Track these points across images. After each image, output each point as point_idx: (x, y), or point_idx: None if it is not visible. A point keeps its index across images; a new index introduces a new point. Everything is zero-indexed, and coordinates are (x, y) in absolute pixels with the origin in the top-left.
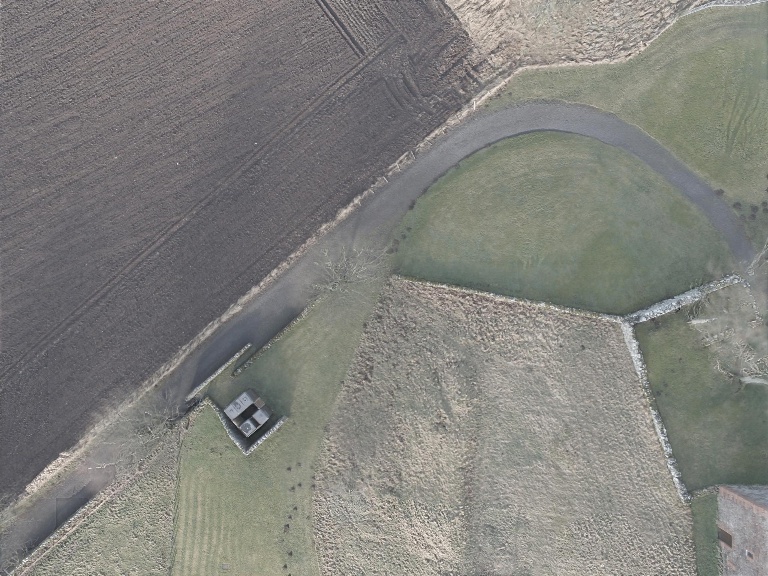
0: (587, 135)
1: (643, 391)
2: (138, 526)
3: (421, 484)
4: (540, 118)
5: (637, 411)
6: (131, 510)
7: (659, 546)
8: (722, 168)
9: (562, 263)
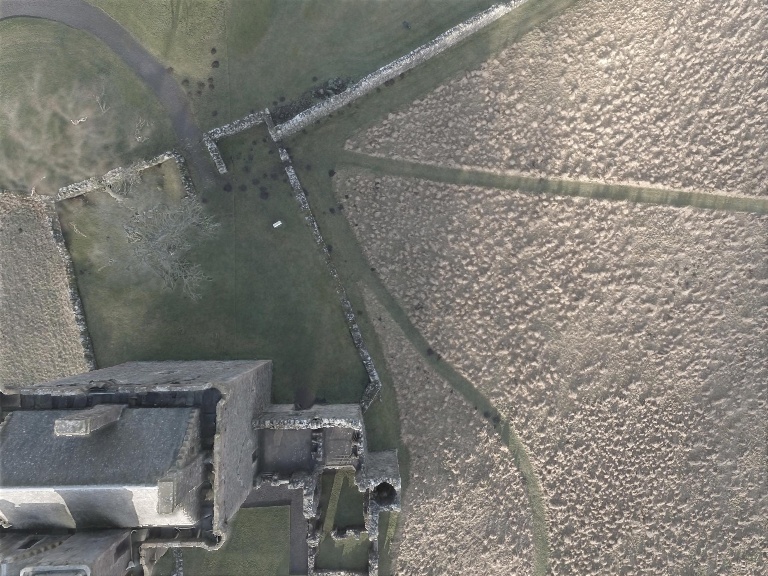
0: (54, 19)
1: (65, 270)
2: None
3: None
4: (12, 4)
5: (61, 291)
6: None
7: None
8: (169, 45)
9: (14, 148)
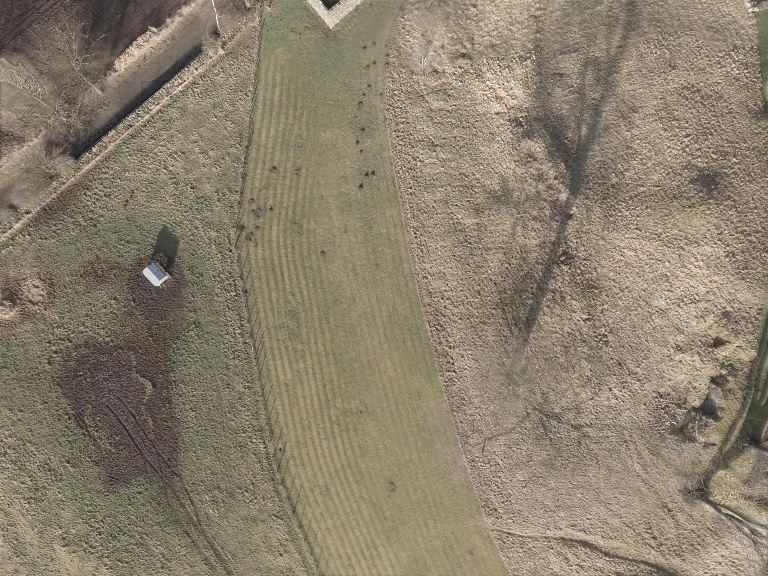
0: None
1: None
2: (218, 107)
3: (493, 41)
4: None
5: None
6: (212, 91)
7: (725, 53)
8: None
9: None
